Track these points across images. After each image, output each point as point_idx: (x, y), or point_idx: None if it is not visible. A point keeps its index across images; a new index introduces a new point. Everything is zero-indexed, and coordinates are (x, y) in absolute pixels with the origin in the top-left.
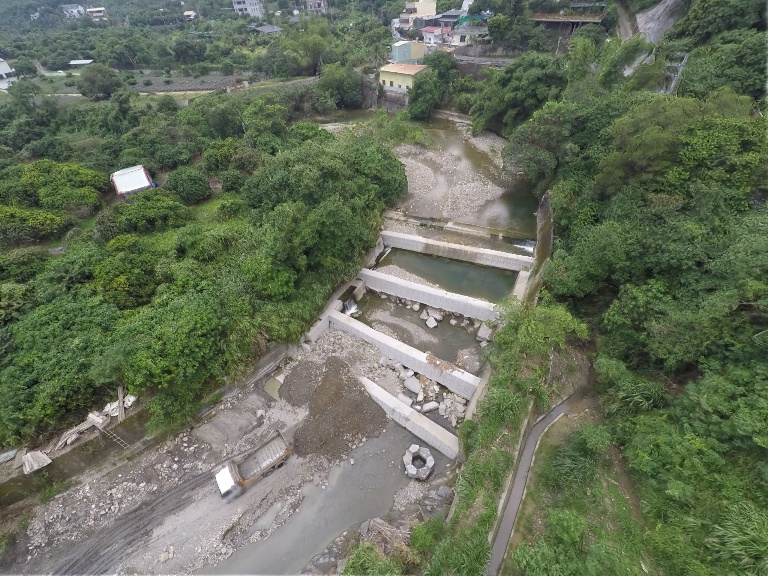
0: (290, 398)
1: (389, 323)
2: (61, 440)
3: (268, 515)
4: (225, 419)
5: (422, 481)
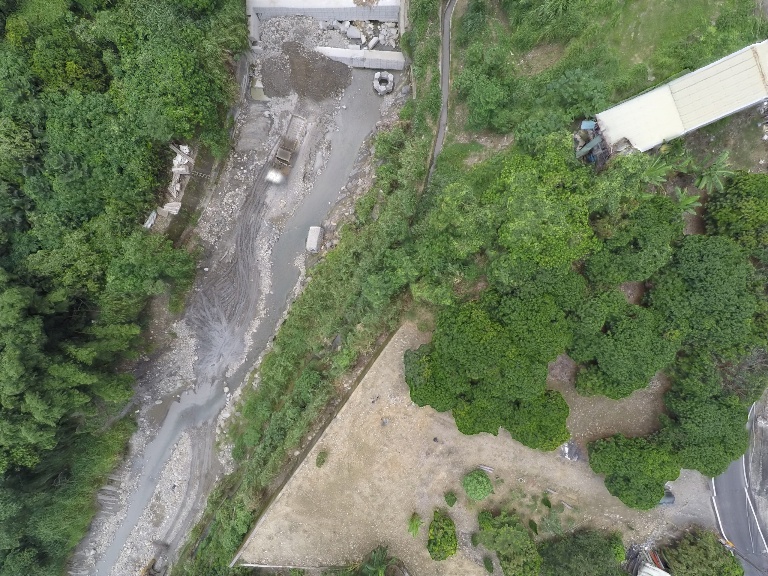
0: (278, 93)
1: None
2: (172, 192)
3: (318, 160)
4: (249, 130)
5: (390, 93)
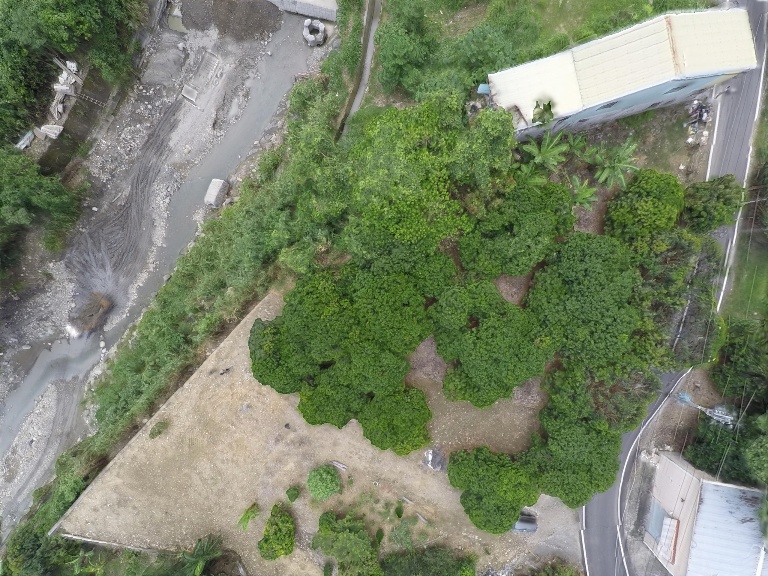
0: (196, 25)
1: None
2: (54, 113)
3: (233, 108)
4: (158, 61)
5: (322, 45)
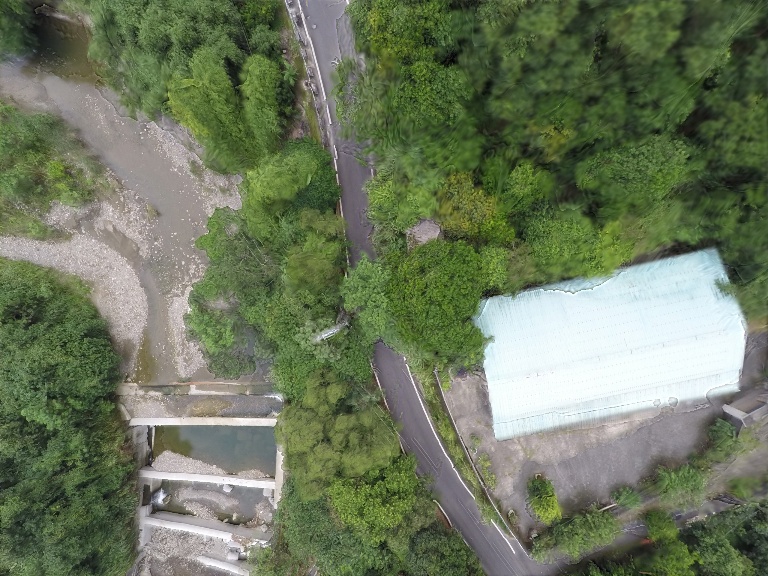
0: None
1: (196, 499)
2: None
3: None
4: None
5: None
